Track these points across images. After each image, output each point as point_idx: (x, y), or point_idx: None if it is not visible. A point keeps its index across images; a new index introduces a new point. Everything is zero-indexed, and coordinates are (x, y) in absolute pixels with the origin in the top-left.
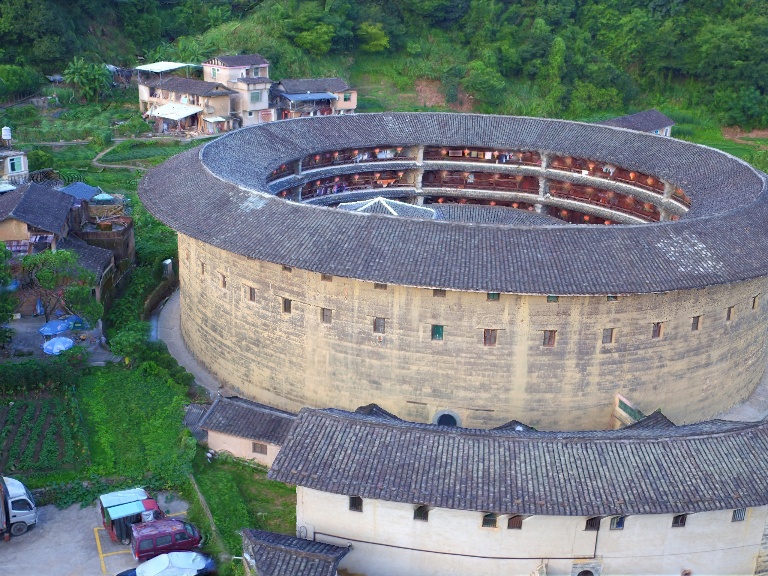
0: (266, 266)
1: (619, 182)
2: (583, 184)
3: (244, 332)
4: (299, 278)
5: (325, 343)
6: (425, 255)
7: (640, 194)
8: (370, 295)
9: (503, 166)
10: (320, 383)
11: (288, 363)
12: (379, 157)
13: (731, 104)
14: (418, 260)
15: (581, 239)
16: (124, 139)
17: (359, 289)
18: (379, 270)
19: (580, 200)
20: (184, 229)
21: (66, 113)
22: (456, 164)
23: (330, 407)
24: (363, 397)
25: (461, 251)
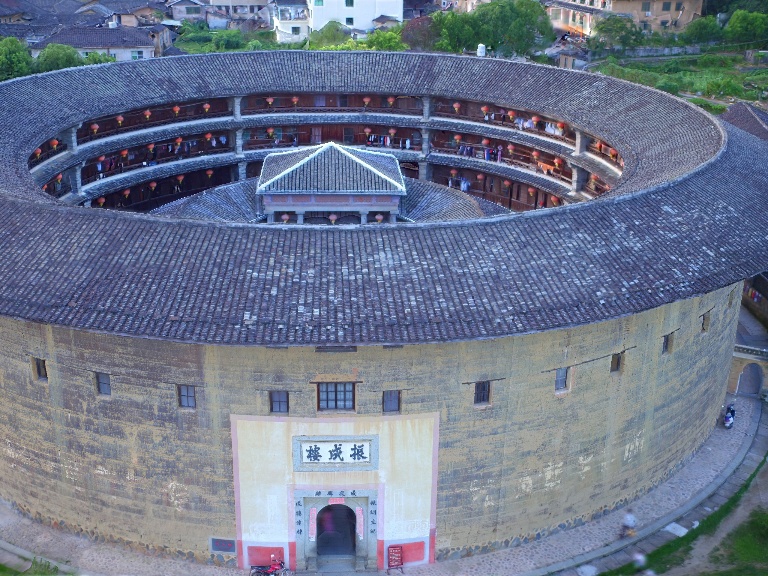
0: None
1: None
2: None
3: None
4: None
5: None
6: None
7: None
8: None
9: None
10: None
11: None
12: (548, 130)
13: None
14: None
15: None
16: (697, 97)
17: None
18: None
19: None
20: None
21: (759, 70)
22: (607, 168)
23: None
24: None
25: None
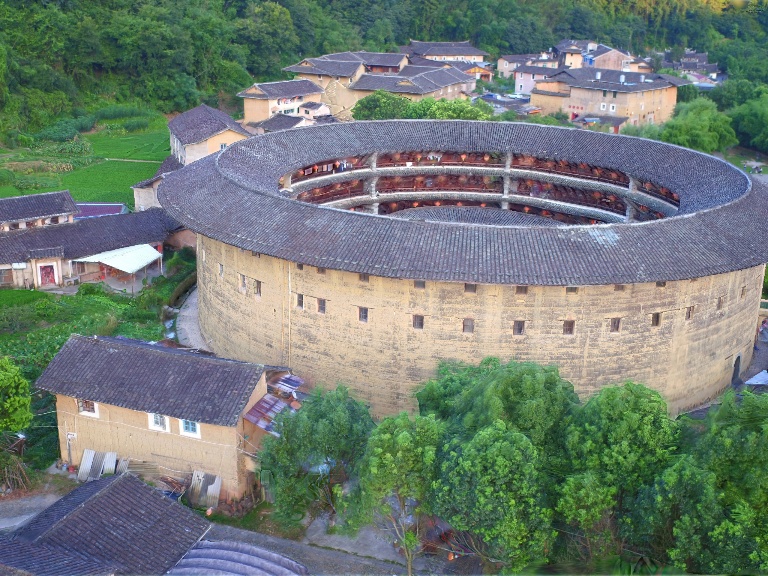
0: (639, 290)
1: (446, 166)
2: (417, 174)
3: (602, 367)
4: (673, 289)
5: (687, 338)
6: (761, 231)
7: (477, 171)
8: (719, 280)
9: (340, 175)
10: (679, 377)
11: (653, 373)
12: None
13: (175, 92)
14: (764, 236)
15: (763, 193)
16: None
17: (714, 278)
18: (763, 251)
19: (406, 190)
20: (592, 281)
21: None
22: (309, 183)
23: (684, 394)
24: (705, 371)
25: (763, 221)
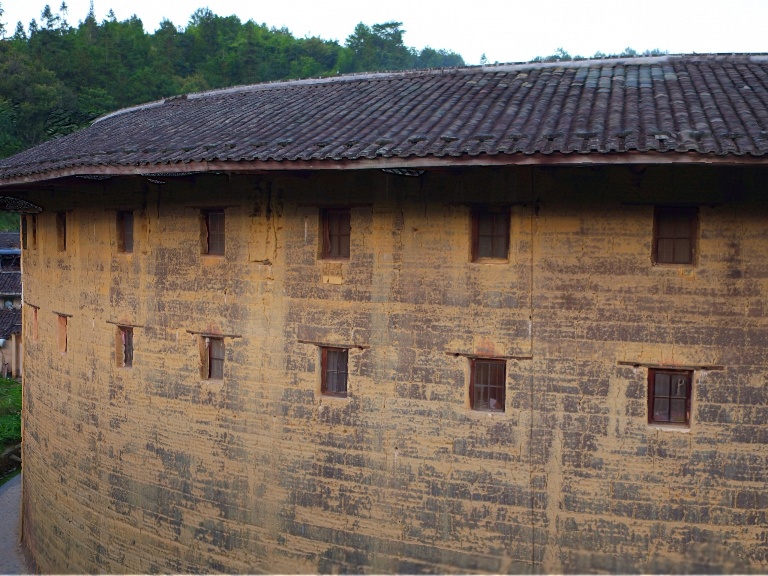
0: (760, 267)
1: None
2: None
3: (622, 553)
4: None
5: None
6: None
7: None
8: None
9: None
10: None
11: None
12: None
13: None
14: None
15: None
16: None
17: None
18: None
19: None
20: None
21: None
22: None
23: None
24: None
25: None
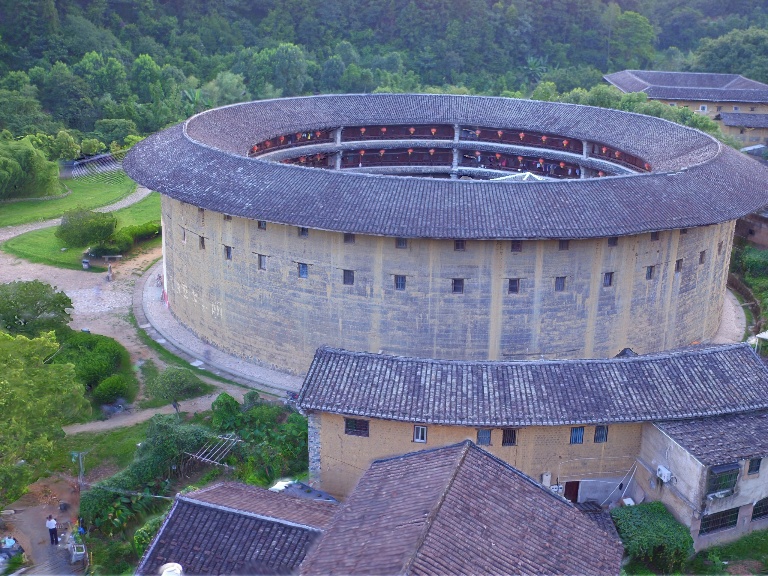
0: None
1: None
2: None
3: None
4: None
5: None
6: None
7: None
8: None
9: None
10: None
11: None
12: None
13: None
14: None
15: None
16: None
17: None
18: None
19: None
20: None
21: None
22: None
23: None
24: None
25: None
